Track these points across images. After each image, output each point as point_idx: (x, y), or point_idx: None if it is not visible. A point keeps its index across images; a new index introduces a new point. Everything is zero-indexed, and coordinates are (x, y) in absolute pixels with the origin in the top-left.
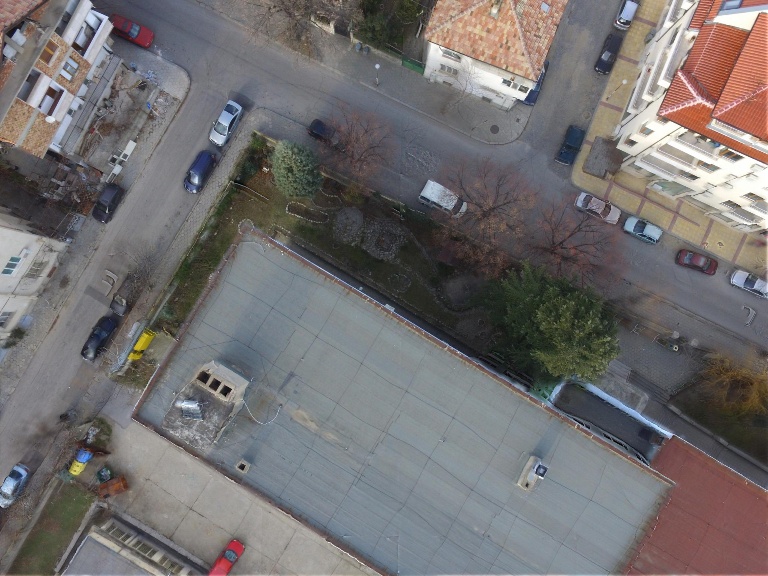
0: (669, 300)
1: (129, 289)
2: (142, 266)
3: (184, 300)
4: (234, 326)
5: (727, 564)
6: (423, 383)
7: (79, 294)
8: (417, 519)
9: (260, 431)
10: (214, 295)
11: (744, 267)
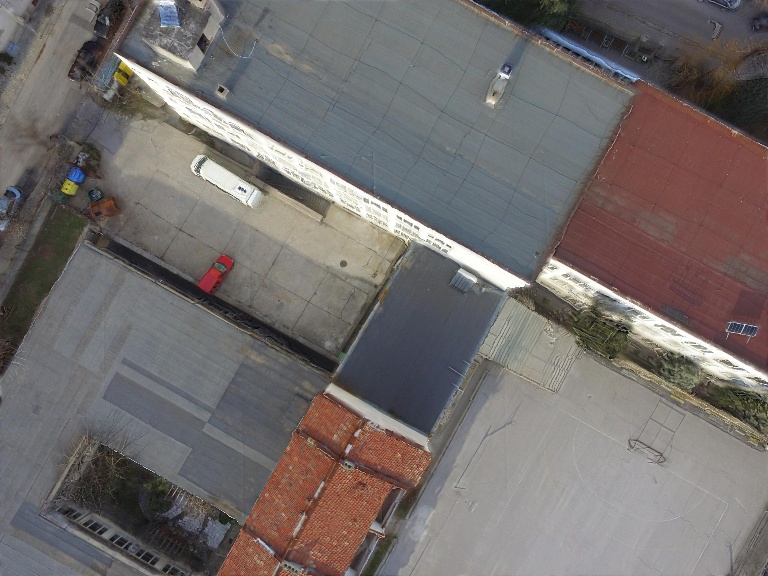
0: (637, 15)
1: (112, 10)
2: None
3: None
4: None
5: (693, 201)
6: (392, 11)
7: (64, 23)
8: (391, 141)
9: (237, 64)
10: None
11: None
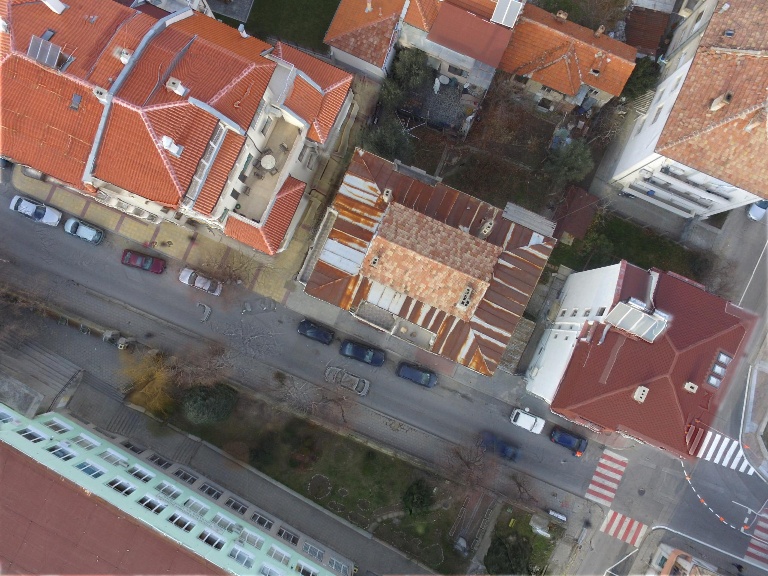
0: (121, 299)
1: None
2: None
3: None
4: None
5: (49, 560)
6: None
7: None
8: None
9: None
10: None
11: (195, 265)
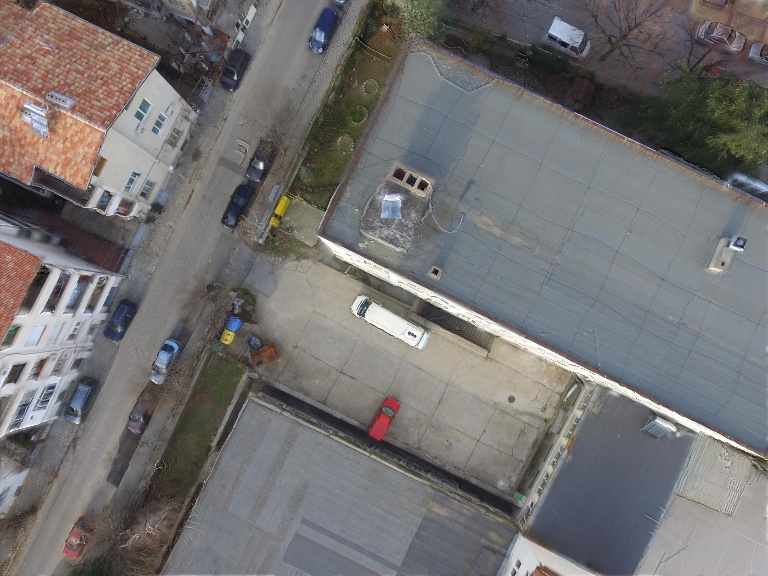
0: None
1: (264, 153)
2: (273, 132)
3: (315, 165)
4: (409, 139)
5: None
6: (605, 177)
7: (212, 166)
8: (611, 313)
9: (446, 240)
10: (386, 110)
11: None
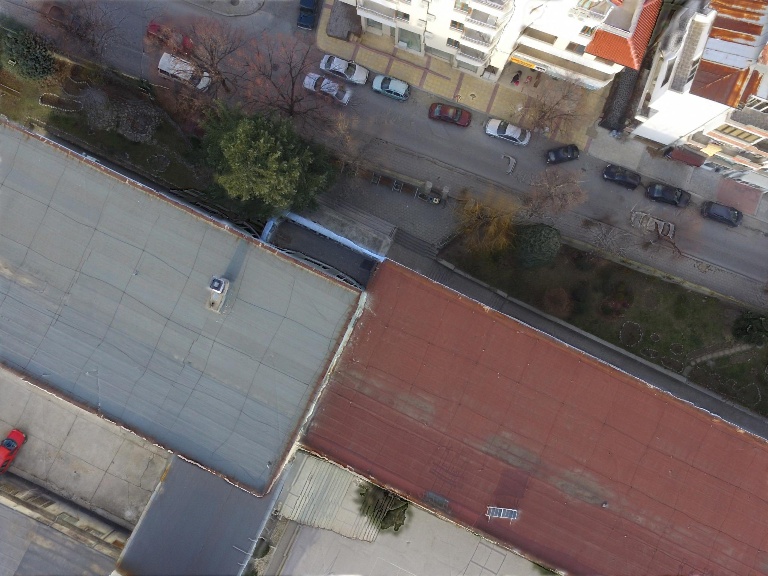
0: (428, 156)
1: None
2: None
3: None
4: None
5: (450, 379)
6: (110, 219)
7: None
8: (116, 353)
9: None
10: None
11: (499, 116)
